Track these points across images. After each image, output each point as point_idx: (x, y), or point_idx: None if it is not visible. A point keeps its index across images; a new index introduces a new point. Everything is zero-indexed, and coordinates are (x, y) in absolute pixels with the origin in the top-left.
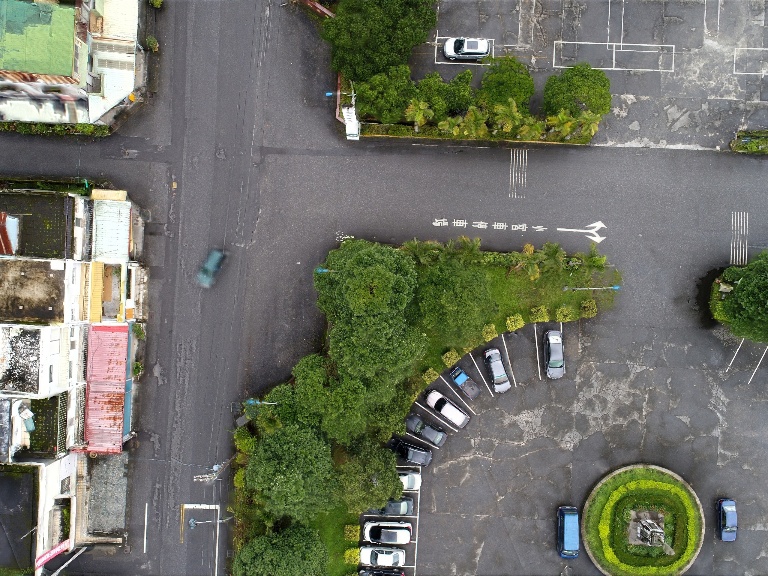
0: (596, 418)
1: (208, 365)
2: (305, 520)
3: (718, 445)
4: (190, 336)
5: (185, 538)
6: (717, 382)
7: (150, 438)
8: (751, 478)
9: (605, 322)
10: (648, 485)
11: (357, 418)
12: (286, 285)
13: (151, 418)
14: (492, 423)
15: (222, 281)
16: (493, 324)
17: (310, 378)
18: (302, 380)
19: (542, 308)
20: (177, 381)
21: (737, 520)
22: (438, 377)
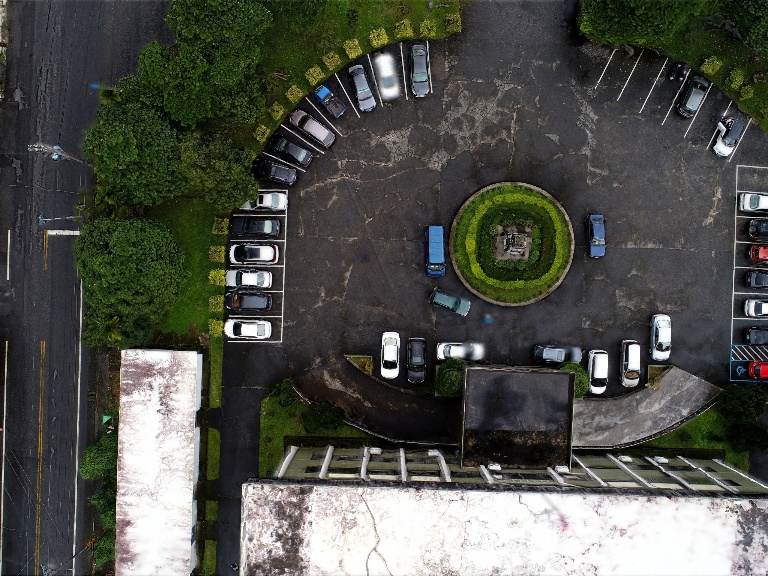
0: (464, 137)
1: (70, 89)
2: (148, 200)
3: (588, 163)
4: (51, 59)
5: (49, 265)
6: (586, 99)
7: (12, 164)
8: (621, 195)
9: (472, 40)
10: (514, 198)
11: (195, 87)
12: (148, 7)
13: (12, 143)
14: (359, 144)
15: (82, 3)
16: (357, 40)
17: (148, 50)
18: (142, 56)
19: (405, 21)
20: (38, 105)
21: (608, 238)
22: (303, 98)
